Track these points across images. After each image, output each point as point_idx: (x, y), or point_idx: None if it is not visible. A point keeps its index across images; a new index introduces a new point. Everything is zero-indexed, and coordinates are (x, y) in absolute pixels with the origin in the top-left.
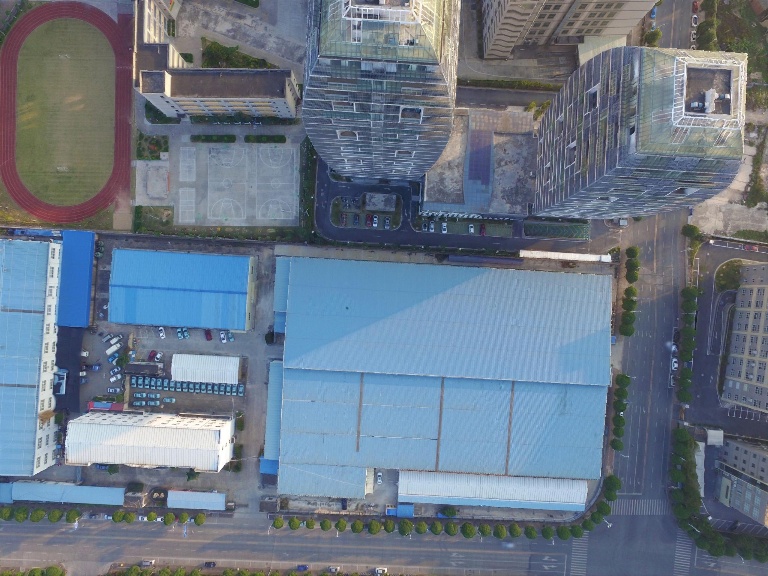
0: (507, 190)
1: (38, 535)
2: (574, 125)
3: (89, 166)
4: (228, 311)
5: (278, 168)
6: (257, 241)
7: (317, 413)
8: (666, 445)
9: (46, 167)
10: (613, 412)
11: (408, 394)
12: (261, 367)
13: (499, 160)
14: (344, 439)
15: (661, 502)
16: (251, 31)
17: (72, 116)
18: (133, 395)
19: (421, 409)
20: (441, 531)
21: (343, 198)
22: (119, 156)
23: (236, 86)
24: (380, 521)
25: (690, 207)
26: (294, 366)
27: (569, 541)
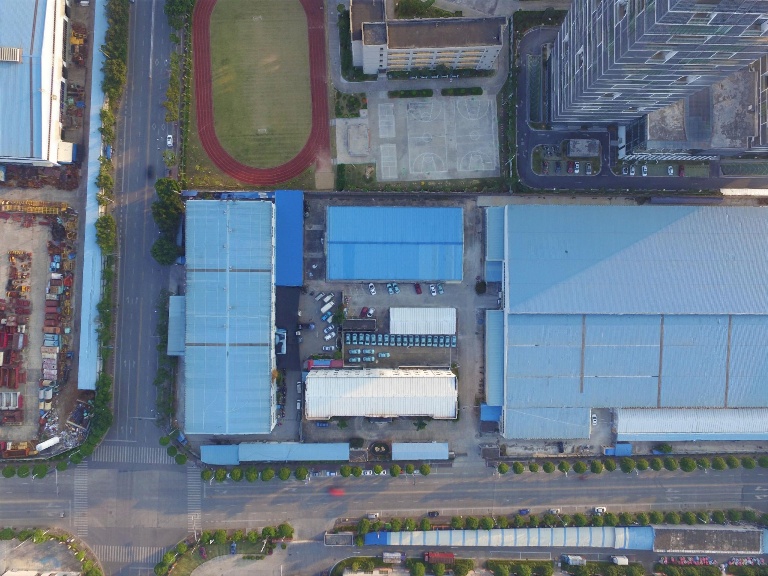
0: (726, 125)
1: (262, 495)
2: None
3: (288, 127)
4: (445, 262)
5: (476, 120)
6: (463, 193)
7: (541, 357)
8: None
9: (245, 130)
10: None
11: (629, 333)
12: (471, 318)
13: (717, 96)
14: (568, 381)
15: None
16: None
17: (268, 78)
18: (348, 352)
19: (642, 347)
20: None
21: (544, 146)
22: (317, 116)
23: (452, 35)
24: None
25: None
26: (520, 311)
27: None
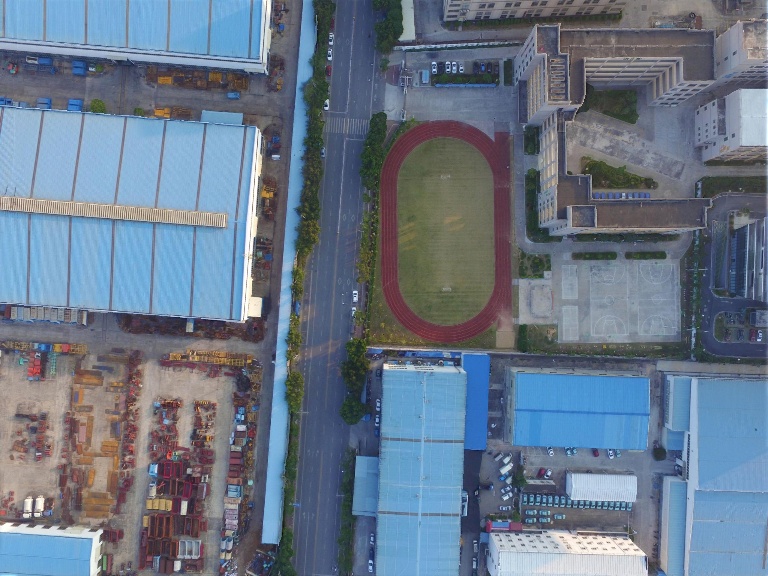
0: None
1: None
2: None
3: (471, 285)
4: (630, 432)
5: (659, 284)
6: (645, 359)
7: (725, 532)
8: None
9: (429, 287)
10: None
11: None
12: (647, 481)
13: None
14: (751, 557)
15: None
16: (629, 147)
17: (453, 236)
18: (524, 512)
19: None
20: None
21: (727, 314)
22: (500, 275)
23: (655, 215)
24: None
25: None
26: (709, 489)
27: None
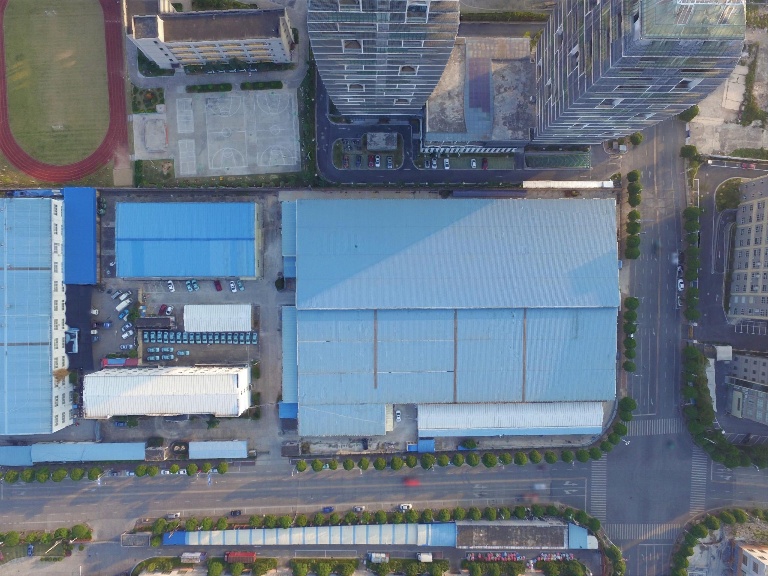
0: (508, 116)
1: (60, 496)
2: (575, 30)
3: (85, 123)
4: (237, 258)
5: (276, 114)
6: (261, 188)
7: (333, 353)
8: (677, 365)
9: (41, 127)
10: (623, 336)
11: (422, 328)
12: (273, 314)
13: (498, 87)
14: (361, 377)
15: (675, 421)
16: None
17: (64, 74)
18: (146, 350)
19: (436, 342)
20: (462, 463)
21: (344, 140)
22: (114, 112)
23: (230, 28)
24: (402, 458)
25: (687, 129)
26: (307, 307)
27: (588, 465)
